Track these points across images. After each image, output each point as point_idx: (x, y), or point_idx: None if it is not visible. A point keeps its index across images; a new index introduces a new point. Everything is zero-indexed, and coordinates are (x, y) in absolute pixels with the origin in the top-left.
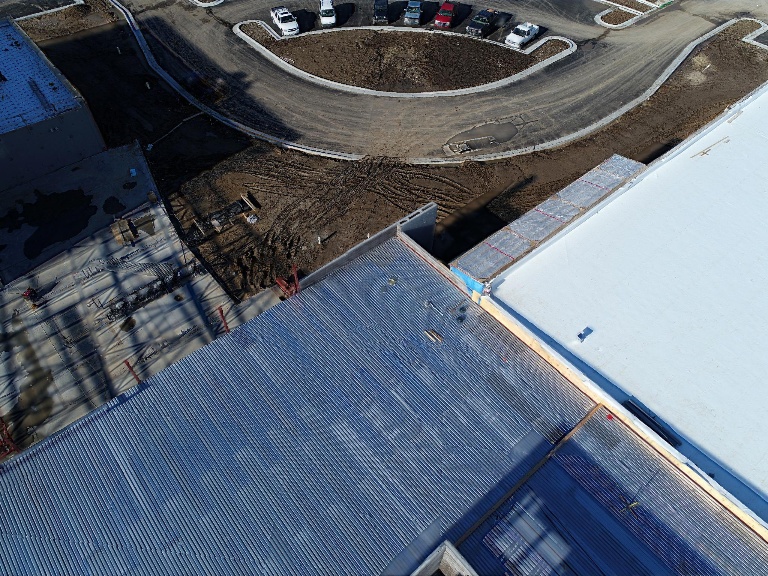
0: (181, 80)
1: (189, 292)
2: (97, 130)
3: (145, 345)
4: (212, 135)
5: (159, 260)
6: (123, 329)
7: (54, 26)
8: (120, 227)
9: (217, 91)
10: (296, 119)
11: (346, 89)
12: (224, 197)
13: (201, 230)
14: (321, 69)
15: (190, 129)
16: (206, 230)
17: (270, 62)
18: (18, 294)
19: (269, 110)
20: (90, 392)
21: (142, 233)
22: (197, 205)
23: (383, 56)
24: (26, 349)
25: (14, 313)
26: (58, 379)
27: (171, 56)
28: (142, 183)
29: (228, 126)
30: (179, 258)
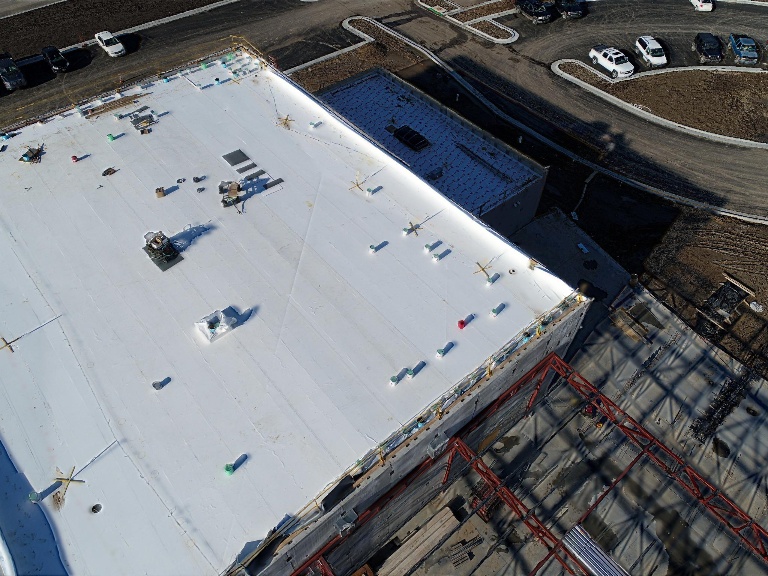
0: (543, 132)
1: (758, 404)
2: (538, 200)
3: (761, 476)
4: (629, 200)
5: (694, 362)
6: (720, 454)
7: (361, 68)
8: (623, 319)
9: (591, 145)
10: (702, 179)
11: (730, 141)
12: (702, 278)
13: (715, 322)
14: (686, 118)
15: (601, 192)
16: (720, 322)
17: (622, 109)
18: (567, 408)
19: (665, 168)
20: (744, 542)
21: (649, 326)
22: (679, 289)
23: (740, 101)
24: (628, 482)
25: (580, 433)
26: (694, 524)
27: (511, 103)
28: (602, 262)
29: (635, 188)
30: (714, 359)
